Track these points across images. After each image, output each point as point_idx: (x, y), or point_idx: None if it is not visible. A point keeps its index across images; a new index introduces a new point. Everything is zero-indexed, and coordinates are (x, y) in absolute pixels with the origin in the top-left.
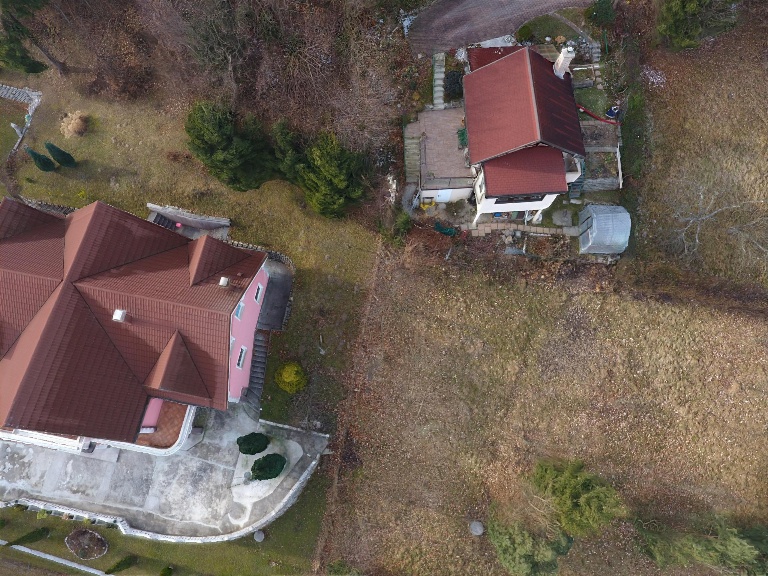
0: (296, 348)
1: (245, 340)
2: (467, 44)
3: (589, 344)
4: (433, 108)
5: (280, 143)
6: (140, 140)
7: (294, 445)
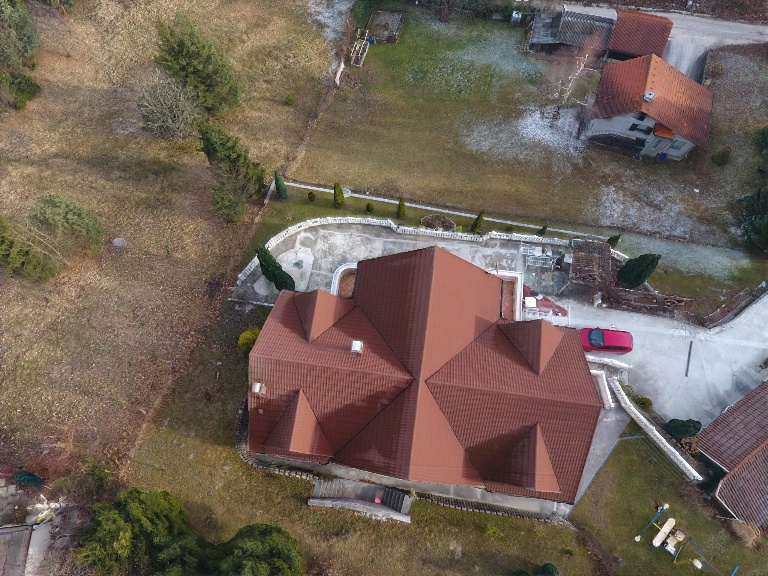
0: (246, 367)
1: None
2: None
3: None
4: None
5: (176, 570)
6: None
7: (261, 291)
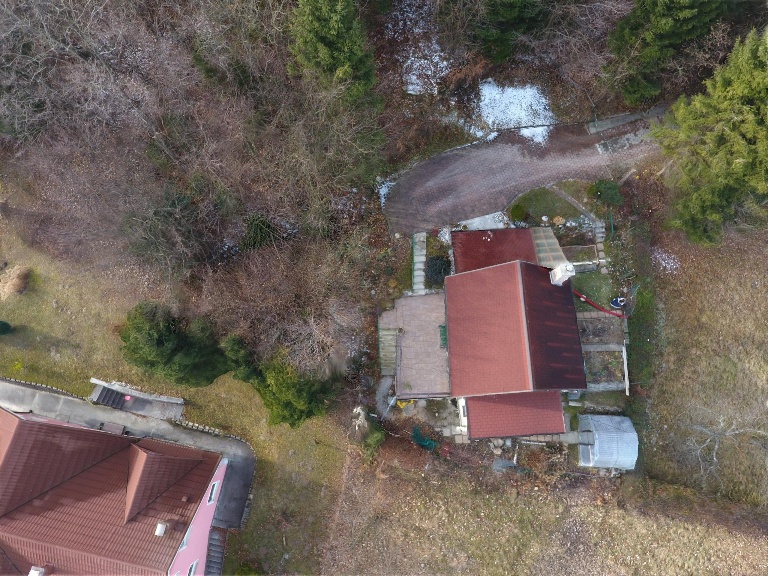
0: (256, 549)
1: (195, 554)
2: (452, 224)
3: (589, 561)
4: (412, 294)
5: (231, 356)
6: (84, 306)
7: None
